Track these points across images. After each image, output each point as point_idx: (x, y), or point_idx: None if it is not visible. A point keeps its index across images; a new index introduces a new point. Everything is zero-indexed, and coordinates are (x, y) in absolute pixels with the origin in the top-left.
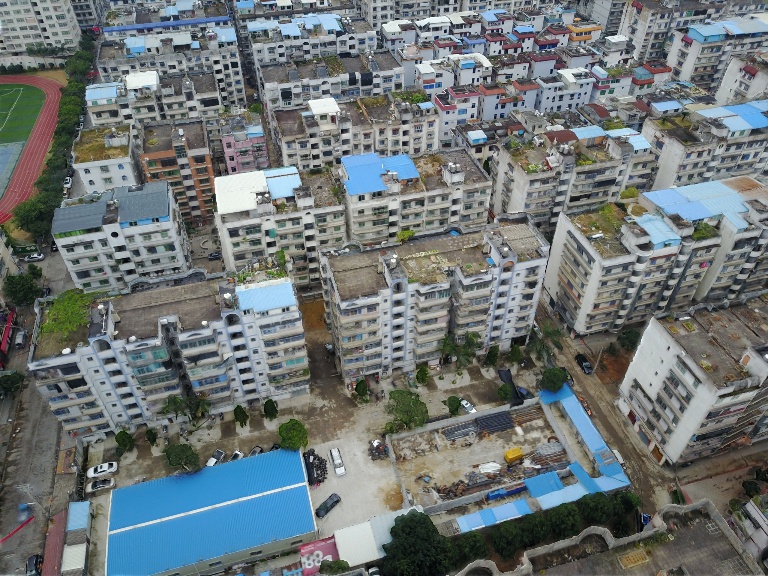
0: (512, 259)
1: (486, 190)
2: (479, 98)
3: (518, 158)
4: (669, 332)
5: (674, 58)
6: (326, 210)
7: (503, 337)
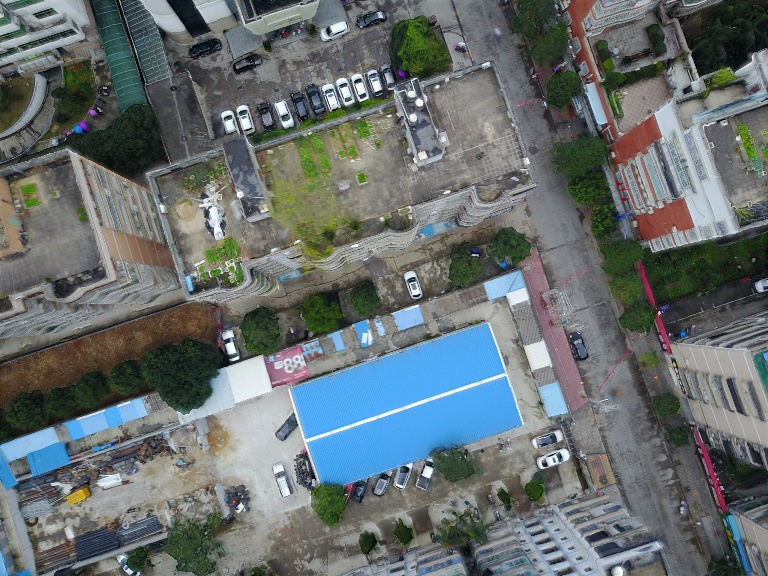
0: None
1: None
2: None
3: None
4: None
5: None
6: None
7: None
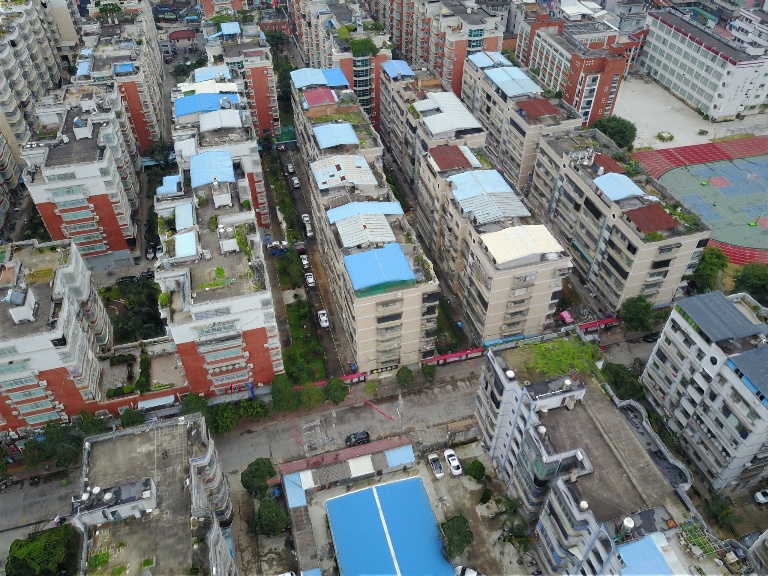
0: None
1: None
2: None
3: None
4: None
5: None
6: None
7: None
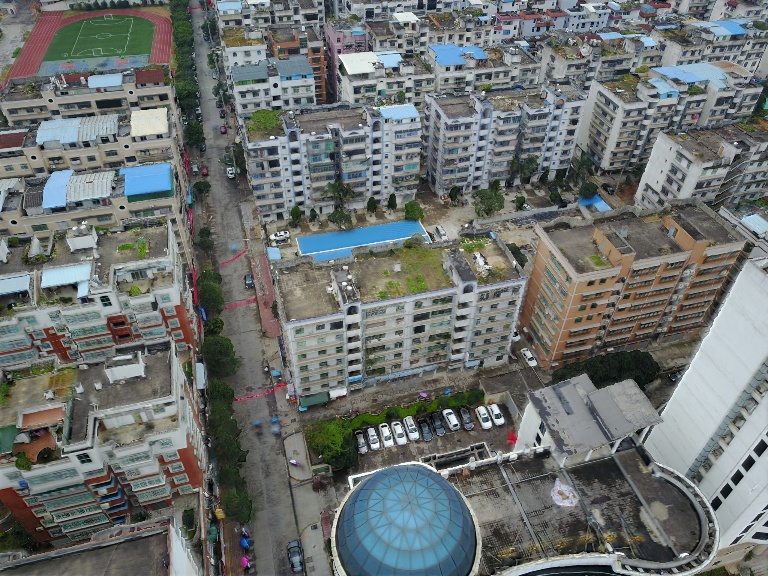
0: (563, 98)
1: (536, 70)
2: (520, 21)
3: (558, 51)
4: (671, 138)
5: (673, 0)
6: (422, 77)
7: (551, 168)
